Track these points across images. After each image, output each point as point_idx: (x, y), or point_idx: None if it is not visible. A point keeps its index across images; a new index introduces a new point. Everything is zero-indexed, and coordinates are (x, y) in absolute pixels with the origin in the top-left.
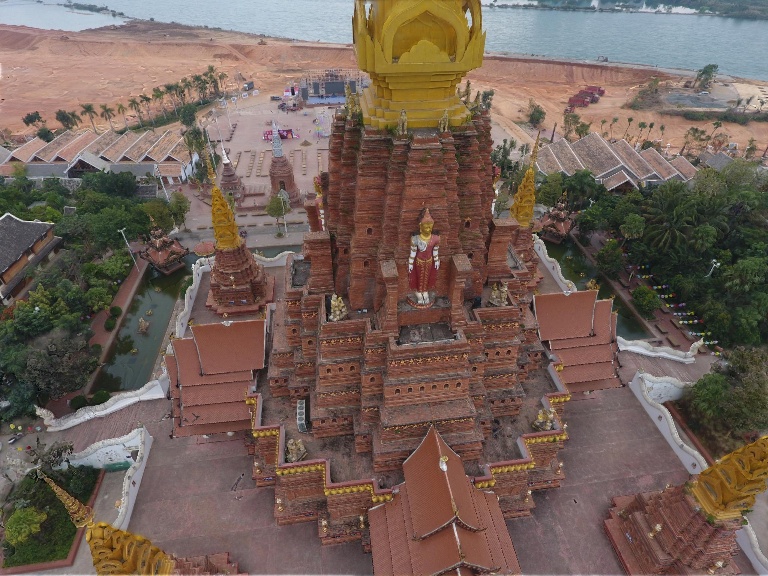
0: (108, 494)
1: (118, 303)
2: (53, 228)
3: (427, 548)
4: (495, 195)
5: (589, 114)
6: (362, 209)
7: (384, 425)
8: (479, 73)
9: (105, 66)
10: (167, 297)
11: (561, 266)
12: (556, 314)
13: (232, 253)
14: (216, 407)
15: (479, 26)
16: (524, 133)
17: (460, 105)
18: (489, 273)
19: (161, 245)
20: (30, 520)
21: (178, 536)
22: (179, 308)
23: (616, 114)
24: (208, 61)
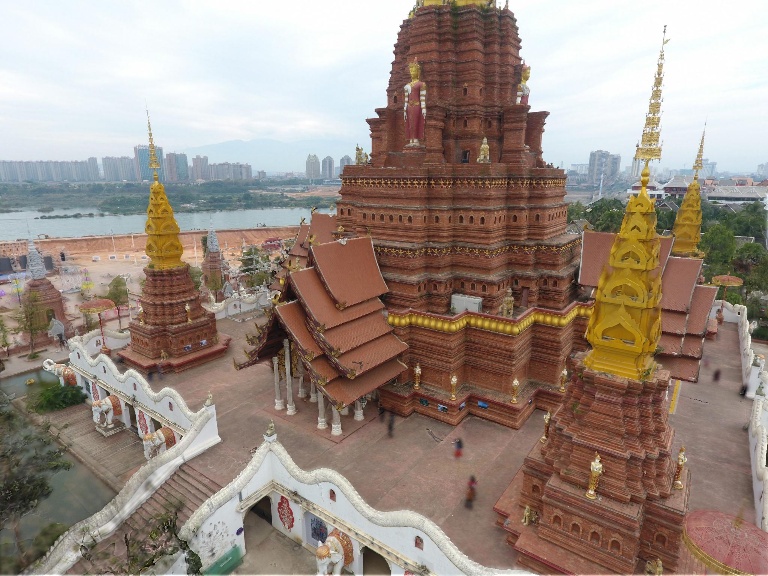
0: None
1: None
2: None
3: (667, 291)
4: None
5: None
6: (478, 68)
7: (561, 244)
8: None
9: None
10: None
11: None
12: None
13: (182, 273)
14: (369, 348)
15: None
16: None
17: None
18: None
19: None
20: None
21: (458, 498)
22: (53, 422)
23: None
24: None
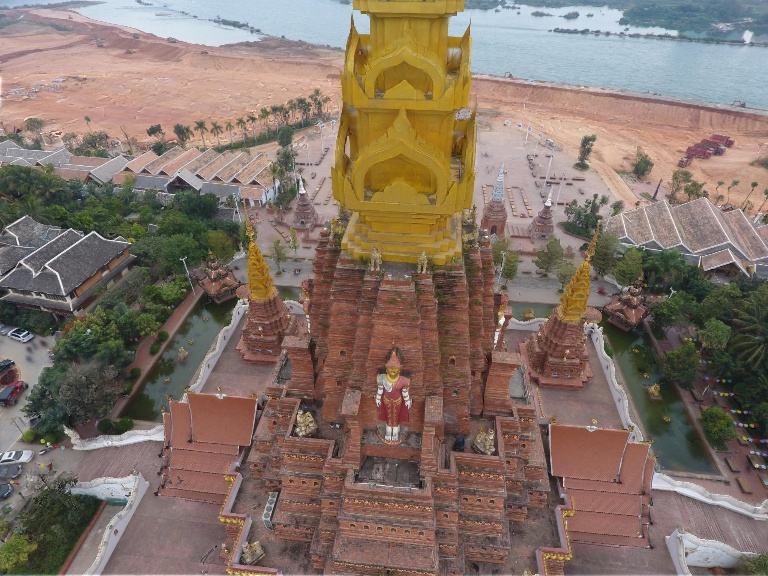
0: (102, 528)
1: (168, 327)
2: (130, 247)
3: None
4: (498, 325)
5: (709, 168)
6: (334, 332)
7: (333, 559)
8: (589, 110)
9: (231, 81)
10: (212, 327)
11: (628, 355)
12: (575, 449)
13: (263, 305)
14: (200, 474)
15: (470, 167)
16: (624, 185)
17: (450, 240)
18: (485, 405)
19: (215, 277)
20: (20, 549)
21: None
22: None
23: (742, 171)
24: (321, 81)
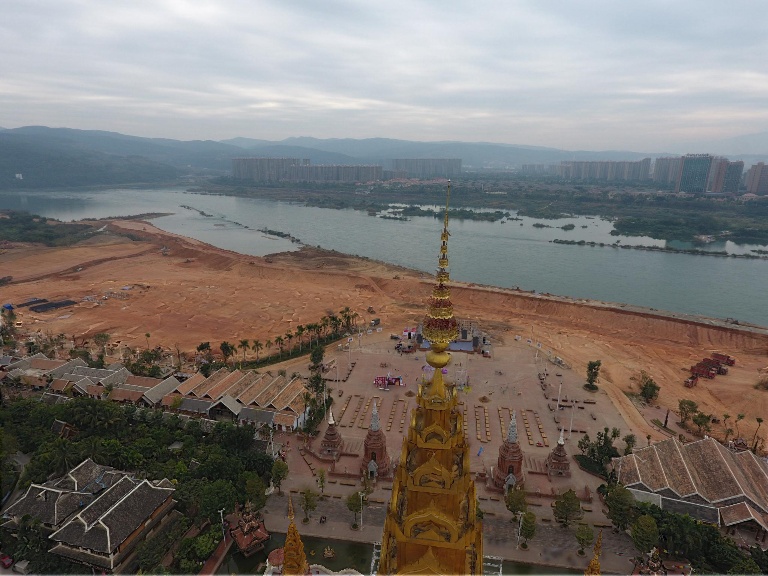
0: None
1: None
2: (173, 494)
3: None
4: None
5: (715, 389)
6: None
7: None
8: (593, 323)
9: (272, 290)
10: None
11: None
12: None
13: None
14: None
15: None
16: (634, 409)
17: None
18: None
19: (248, 530)
20: None
21: None
22: None
23: (748, 395)
24: (350, 290)
